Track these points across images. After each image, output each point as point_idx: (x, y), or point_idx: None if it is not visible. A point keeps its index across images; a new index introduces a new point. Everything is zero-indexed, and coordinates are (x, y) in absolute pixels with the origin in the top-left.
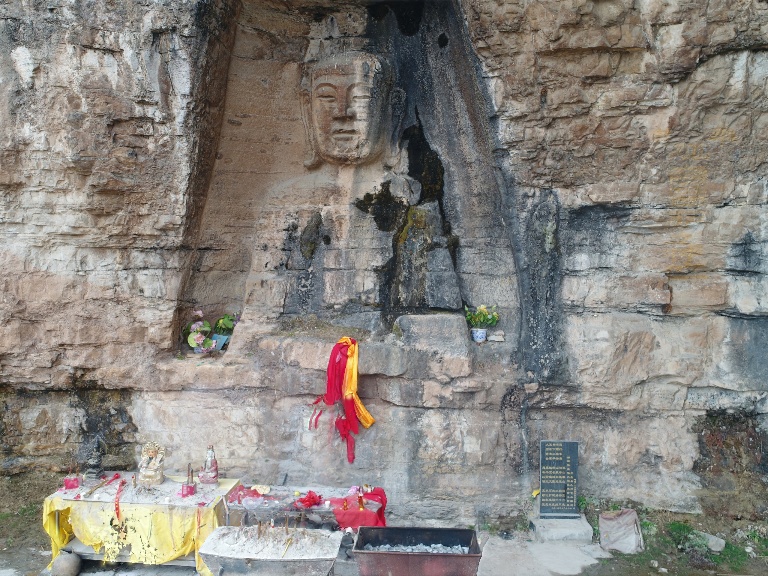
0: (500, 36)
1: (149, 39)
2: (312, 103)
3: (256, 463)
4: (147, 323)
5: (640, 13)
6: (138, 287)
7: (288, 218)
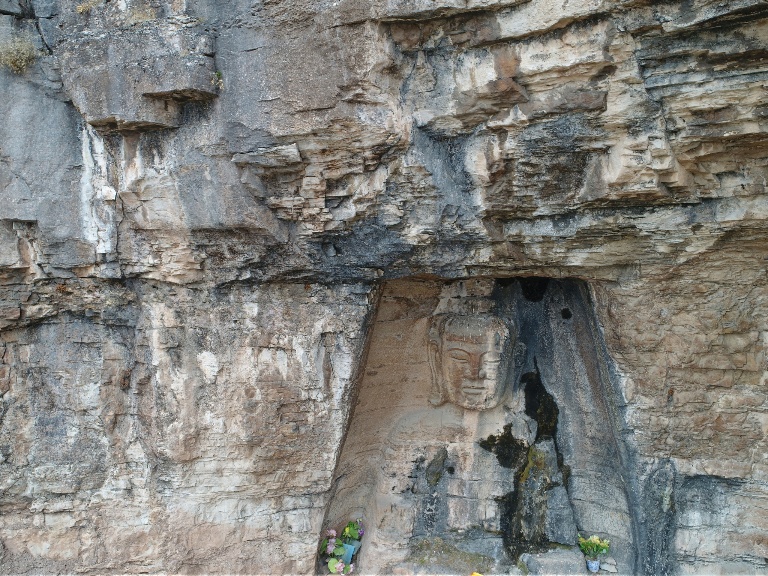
0: (637, 354)
1: (318, 339)
2: (442, 356)
3: None
4: (295, 557)
5: (763, 342)
6: (287, 525)
7: (417, 452)
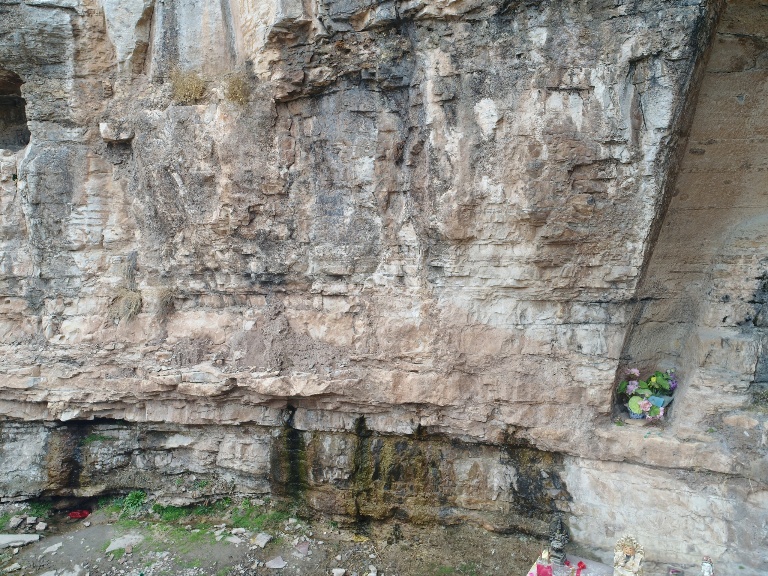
0: None
1: (625, 70)
2: None
3: (726, 567)
4: (586, 383)
5: None
6: (576, 343)
7: (764, 264)
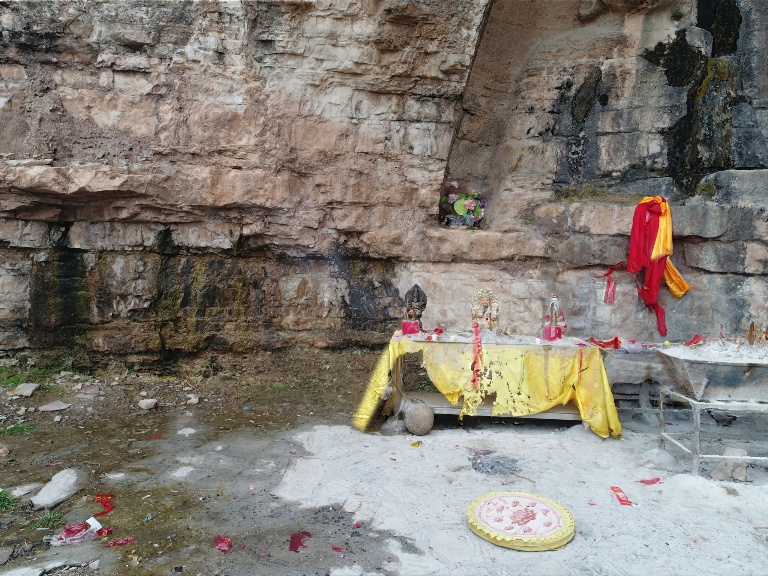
0: None
1: None
2: None
3: None
4: (418, 183)
5: None
6: (408, 143)
7: (563, 74)
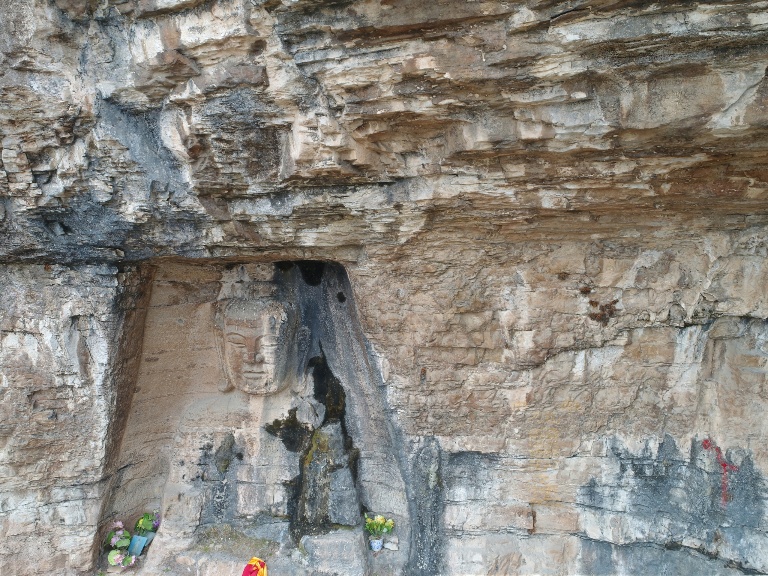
0: (384, 334)
1: (68, 323)
2: (224, 342)
3: None
4: (68, 551)
5: (499, 321)
6: (59, 517)
7: (203, 439)
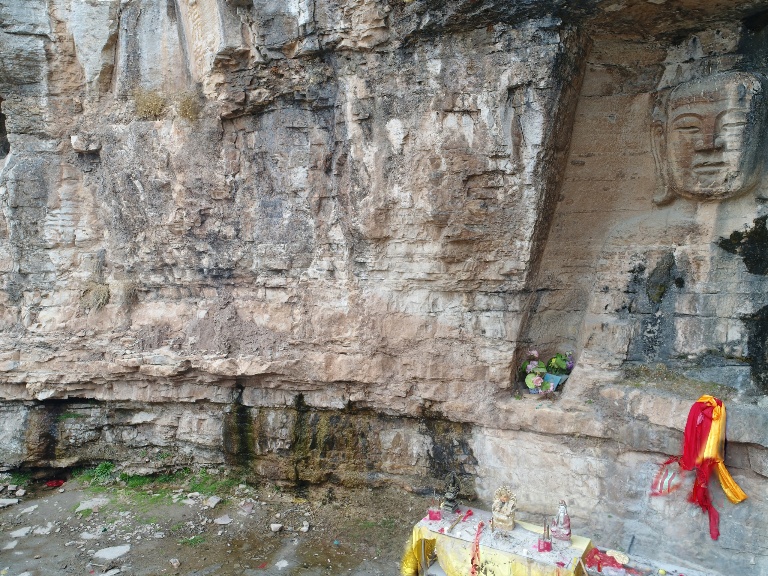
0: None
1: (505, 96)
2: (667, 135)
3: (598, 517)
4: (488, 363)
5: None
6: (480, 328)
7: (634, 259)
